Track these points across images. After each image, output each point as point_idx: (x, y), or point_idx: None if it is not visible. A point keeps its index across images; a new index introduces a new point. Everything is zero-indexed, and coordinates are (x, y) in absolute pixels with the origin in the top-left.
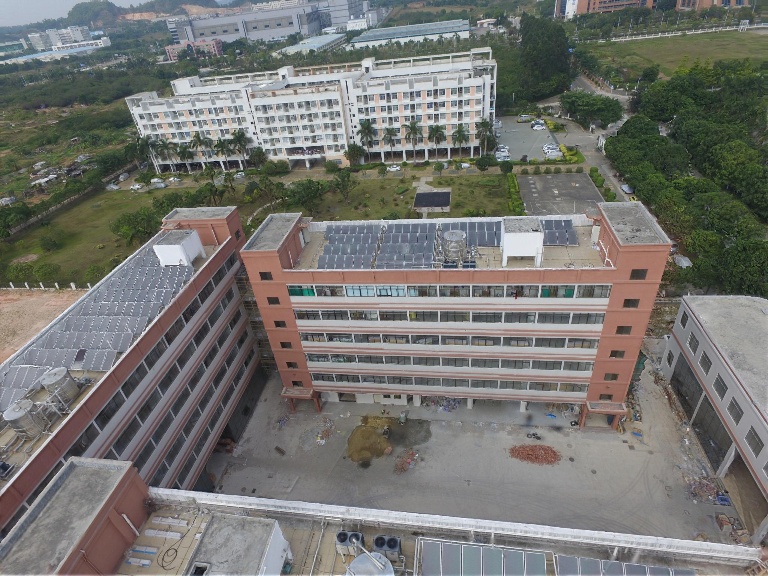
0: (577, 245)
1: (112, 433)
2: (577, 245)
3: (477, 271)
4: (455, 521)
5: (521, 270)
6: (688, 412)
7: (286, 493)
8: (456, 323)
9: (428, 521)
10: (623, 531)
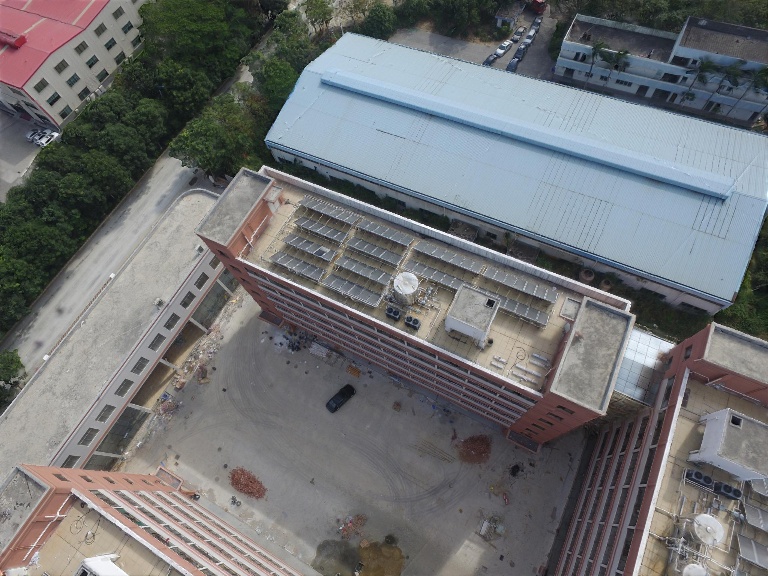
0: (46, 574)
1: (621, 534)
2: (46, 574)
3: (184, 568)
4: (354, 310)
5: (145, 540)
6: (110, 468)
7: (470, 540)
8: (236, 571)
9: (367, 315)
10: (238, 403)
